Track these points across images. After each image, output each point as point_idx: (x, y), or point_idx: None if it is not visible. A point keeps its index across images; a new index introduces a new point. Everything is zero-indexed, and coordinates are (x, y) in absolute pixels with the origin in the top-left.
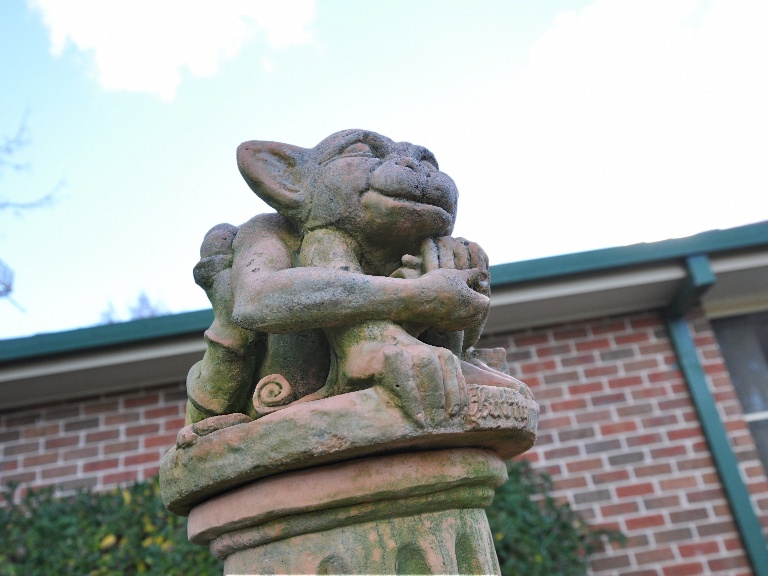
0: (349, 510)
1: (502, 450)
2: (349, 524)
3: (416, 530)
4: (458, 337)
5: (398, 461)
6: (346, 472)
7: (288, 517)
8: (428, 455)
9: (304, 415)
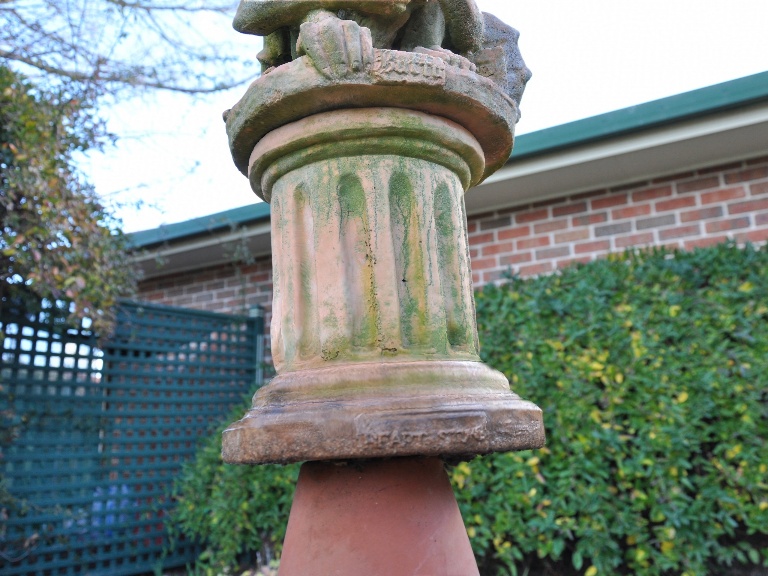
0: (307, 150)
1: (476, 126)
2: (312, 162)
3: (356, 165)
4: (430, 31)
5: (335, 113)
6: (301, 123)
7: (278, 160)
8: (360, 109)
9: (262, 81)
